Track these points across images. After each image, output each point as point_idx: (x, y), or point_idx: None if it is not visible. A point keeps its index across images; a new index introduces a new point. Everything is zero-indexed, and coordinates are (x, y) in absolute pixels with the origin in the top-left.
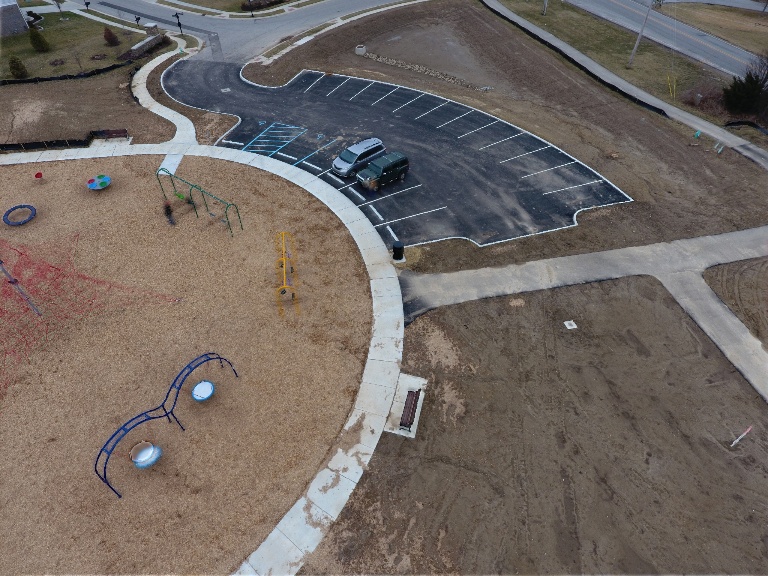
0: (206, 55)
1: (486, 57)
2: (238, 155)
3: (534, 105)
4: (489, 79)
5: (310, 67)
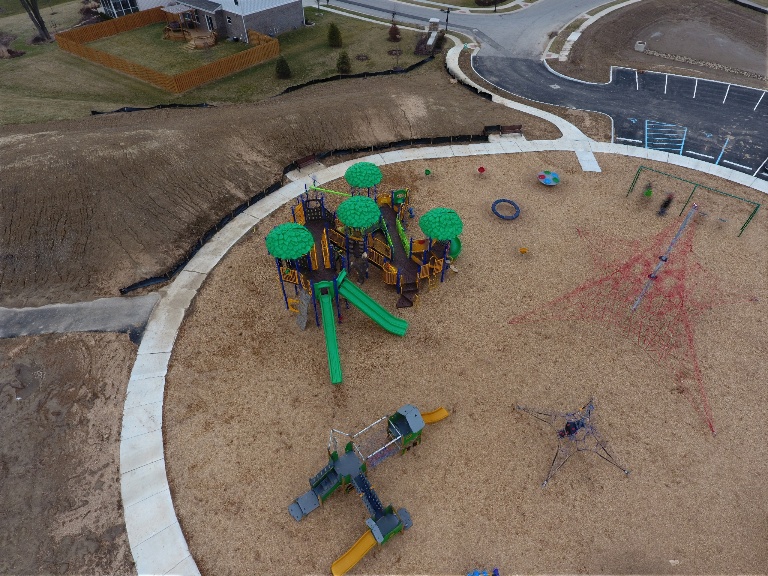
0: (492, 51)
1: None
2: (648, 153)
3: None
4: None
5: (617, 63)
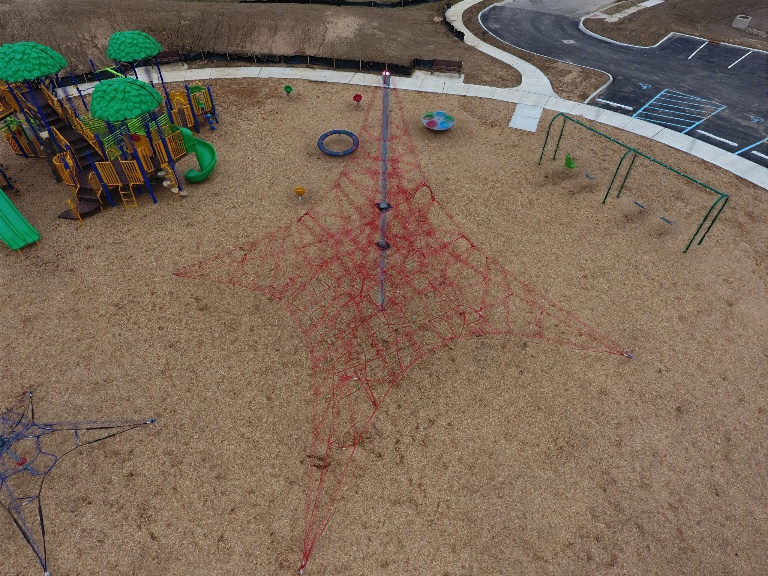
0: (525, 4)
1: None
2: (629, 122)
3: None
4: None
5: (683, 30)
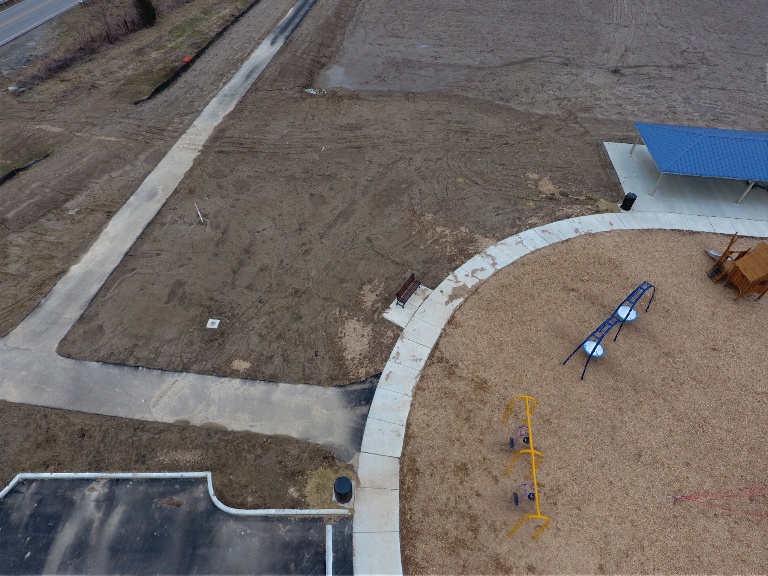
0: None
1: None
2: None
3: None
4: None
5: None
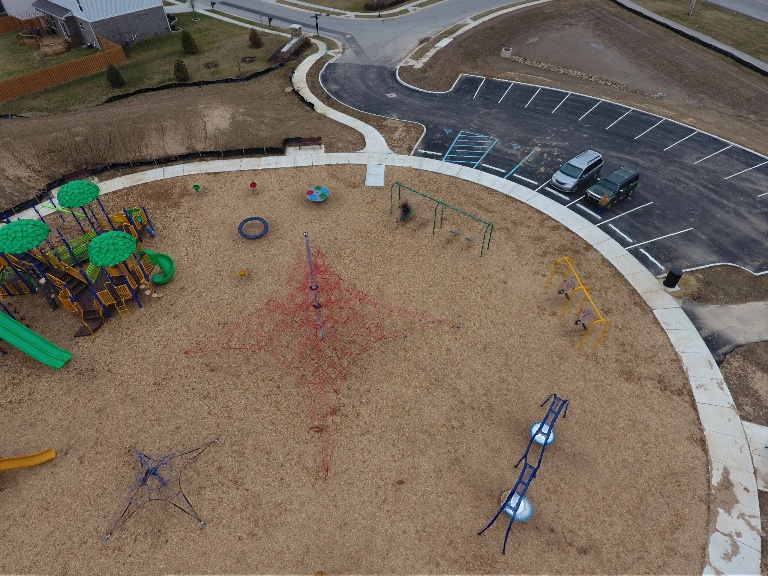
0: (352, 58)
1: (642, 61)
2: (441, 166)
3: (722, 114)
4: (656, 85)
5: (467, 71)
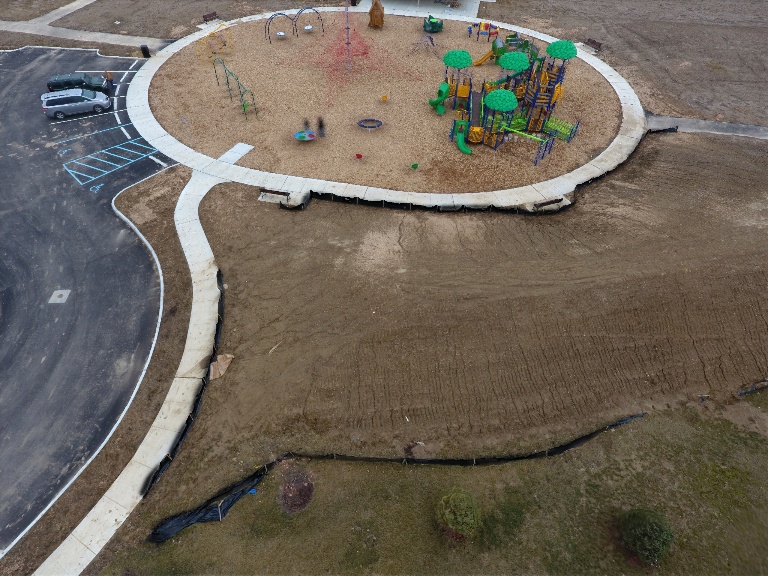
0: None
1: None
2: (167, 145)
3: None
4: None
5: None
